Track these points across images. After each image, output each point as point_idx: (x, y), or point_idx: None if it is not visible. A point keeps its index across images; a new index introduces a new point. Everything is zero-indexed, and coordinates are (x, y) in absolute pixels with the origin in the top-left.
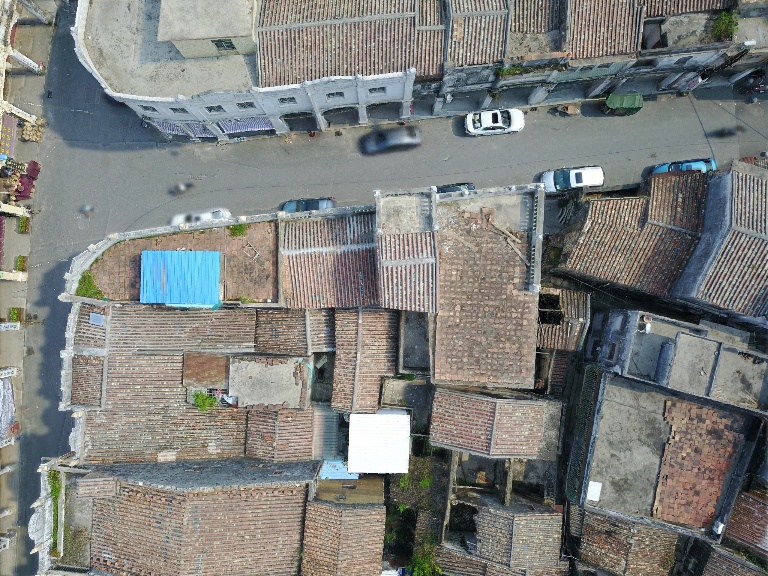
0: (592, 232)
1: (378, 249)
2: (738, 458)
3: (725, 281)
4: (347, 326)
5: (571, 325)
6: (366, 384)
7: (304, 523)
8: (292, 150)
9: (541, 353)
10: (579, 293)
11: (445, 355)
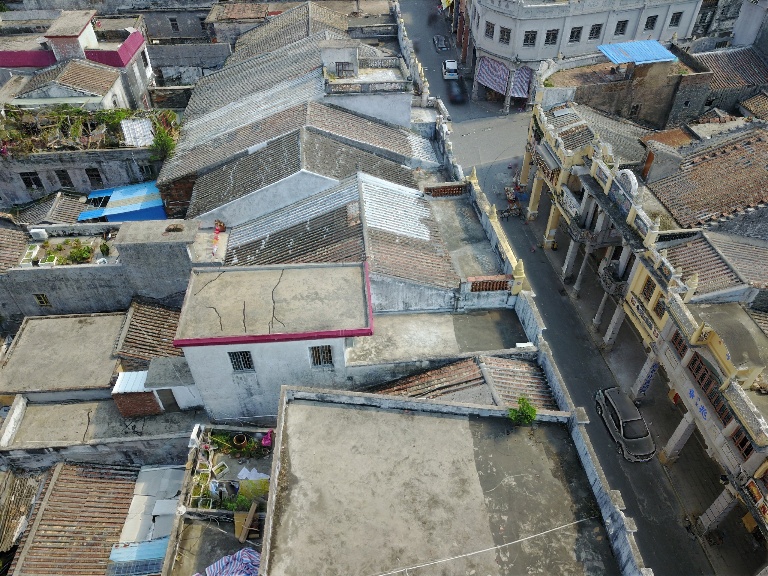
0: None
1: None
2: None
3: None
4: (760, 104)
5: None
6: None
7: None
8: None
9: None
10: None
11: None
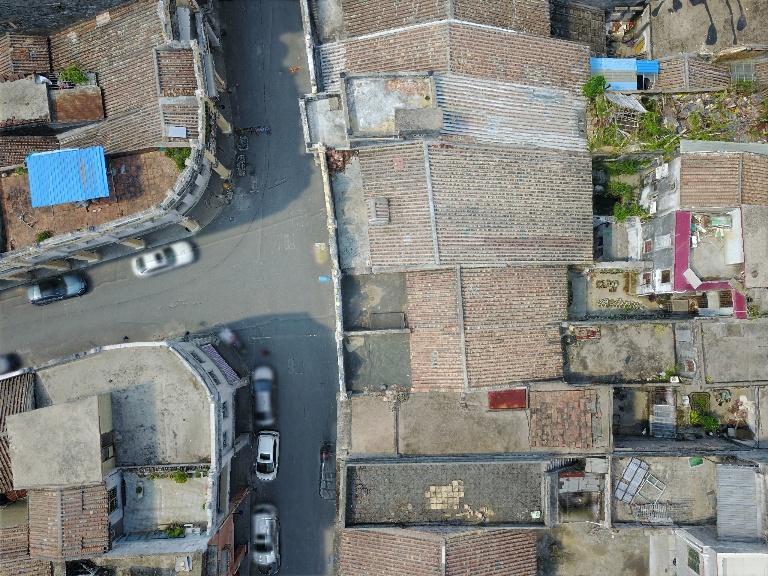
0: None
1: None
2: None
3: None
4: None
5: None
6: None
7: None
8: (88, 346)
9: None
10: None
11: None
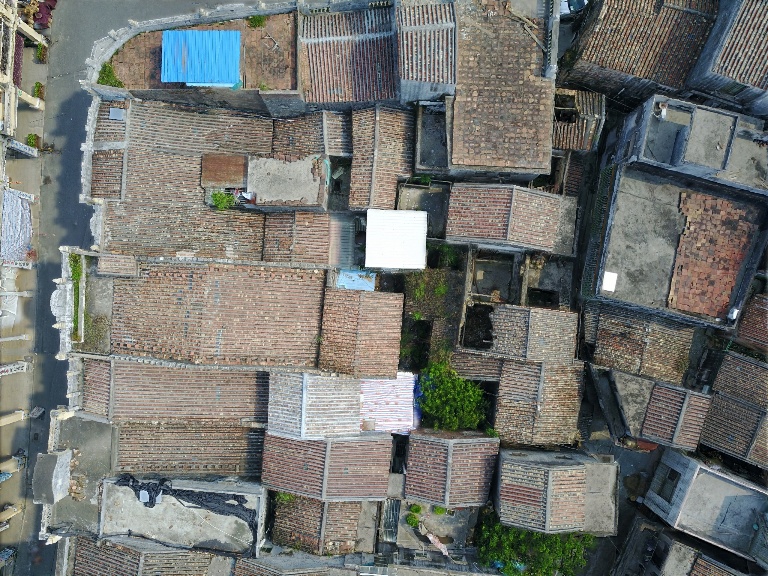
0: (608, 19)
1: (398, 17)
2: (752, 249)
3: (741, 52)
4: (364, 125)
5: (587, 122)
6: (383, 182)
7: None
8: None
9: (556, 156)
10: (594, 93)
11: (463, 140)
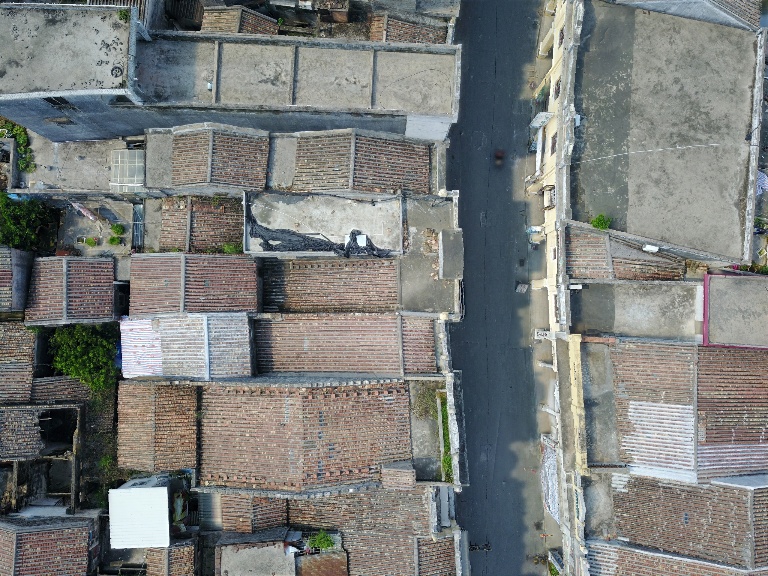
0: None
1: None
2: None
3: None
4: None
5: None
6: (159, 574)
7: (200, 442)
8: None
9: None
10: None
11: None
